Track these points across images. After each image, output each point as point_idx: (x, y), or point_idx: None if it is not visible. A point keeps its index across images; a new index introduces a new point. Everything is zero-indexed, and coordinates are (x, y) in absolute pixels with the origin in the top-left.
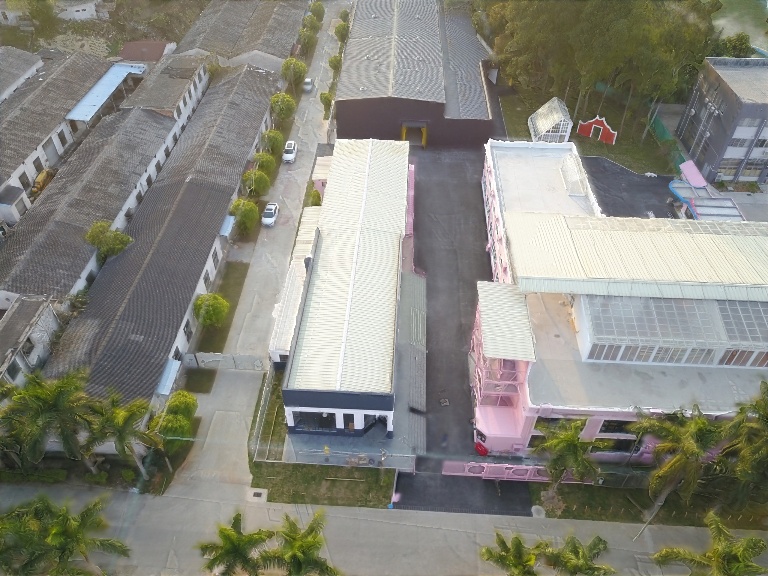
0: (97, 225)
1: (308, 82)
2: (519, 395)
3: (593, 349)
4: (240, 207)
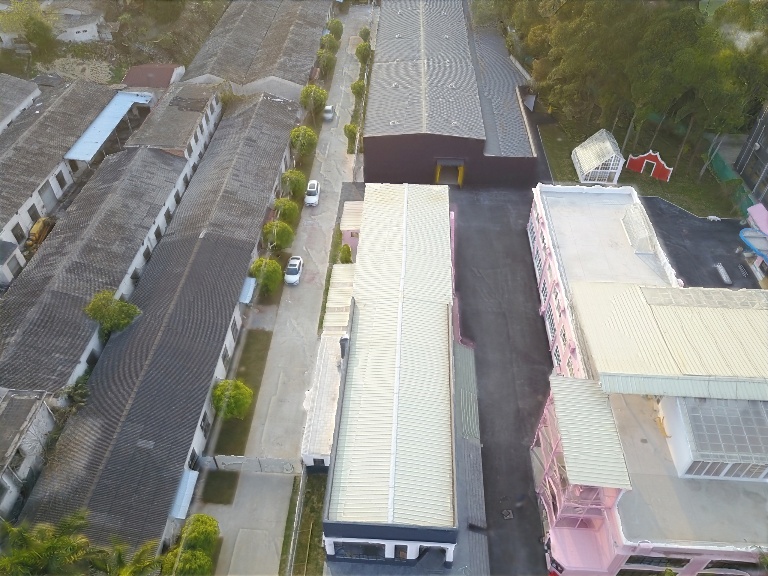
0: (99, 297)
1: (329, 110)
2: (604, 519)
3: (693, 465)
4: (262, 268)
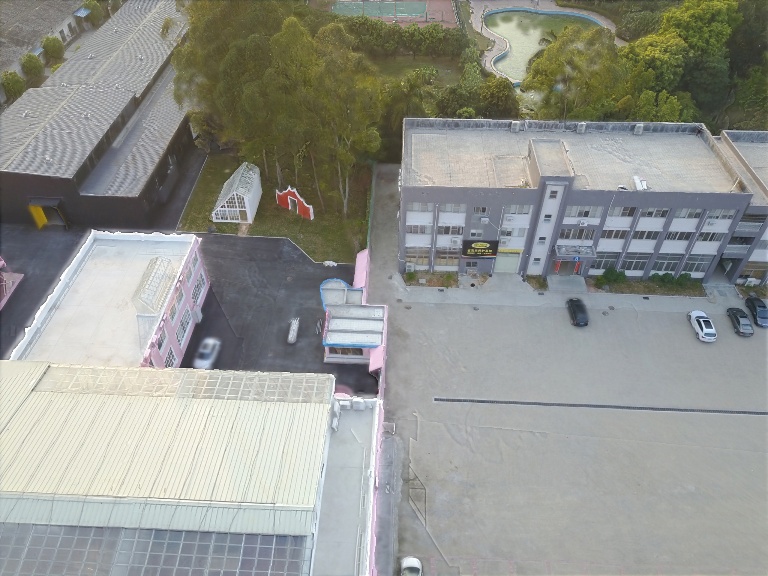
0: None
1: None
2: None
3: None
4: None
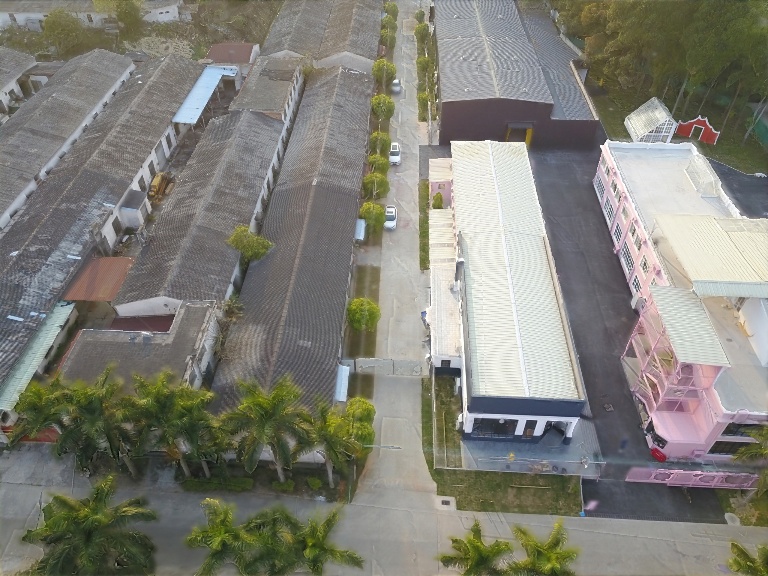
0: (241, 229)
1: (396, 83)
2: (701, 400)
3: None
4: (371, 210)
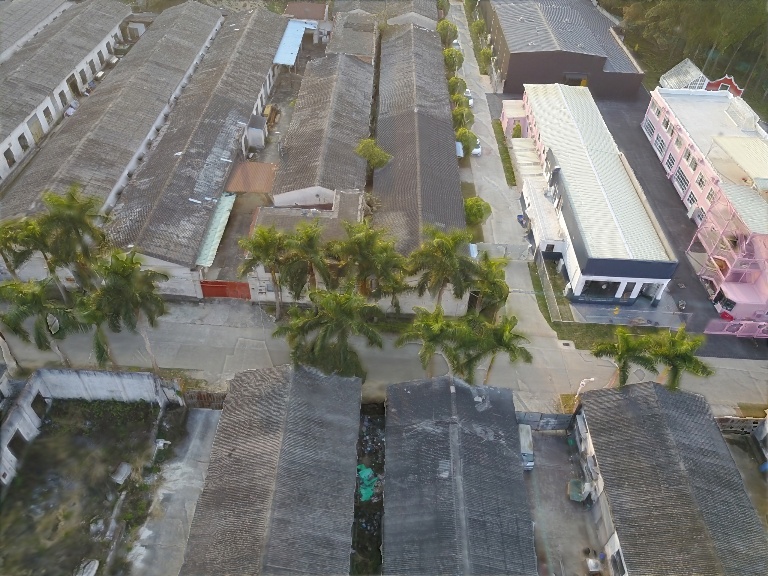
0: (368, 141)
1: (455, 43)
2: (762, 271)
3: None
4: (467, 134)
